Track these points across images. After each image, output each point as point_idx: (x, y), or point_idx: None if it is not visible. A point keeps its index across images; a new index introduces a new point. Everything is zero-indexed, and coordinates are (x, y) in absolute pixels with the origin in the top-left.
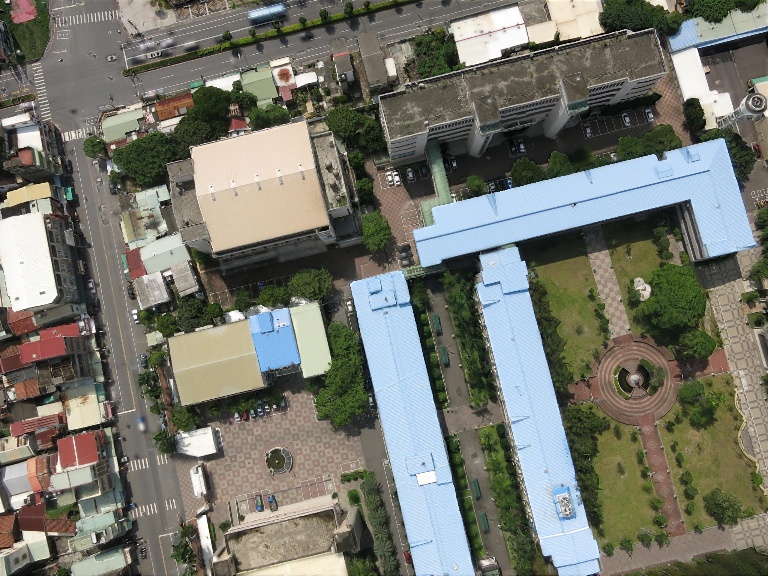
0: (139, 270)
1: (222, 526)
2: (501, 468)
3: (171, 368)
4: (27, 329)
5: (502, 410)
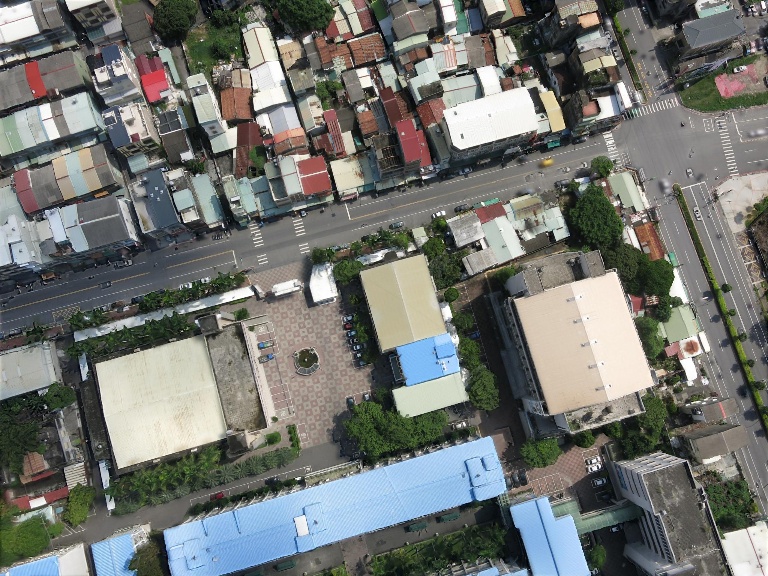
0: (485, 216)
1: (245, 312)
2: None
3: (396, 260)
4: (423, 117)
5: None
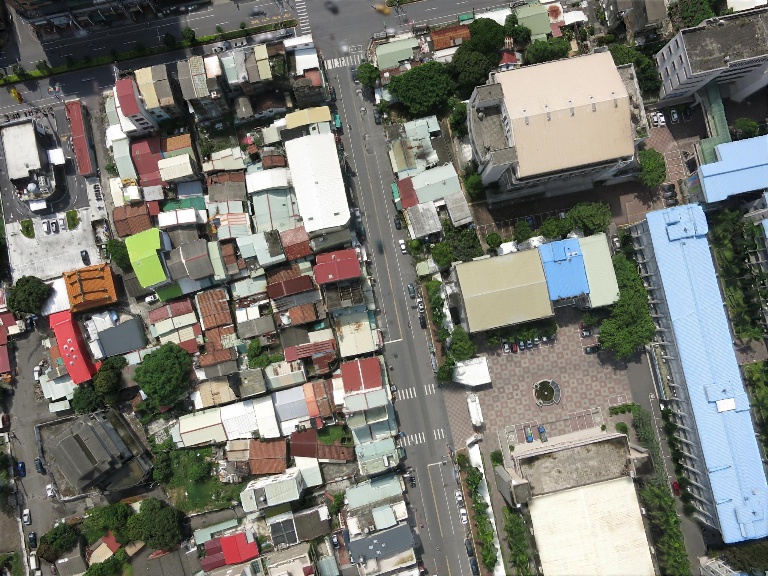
0: (411, 199)
1: (497, 455)
2: (765, 404)
3: (461, 294)
4: (300, 254)
5: (766, 347)
